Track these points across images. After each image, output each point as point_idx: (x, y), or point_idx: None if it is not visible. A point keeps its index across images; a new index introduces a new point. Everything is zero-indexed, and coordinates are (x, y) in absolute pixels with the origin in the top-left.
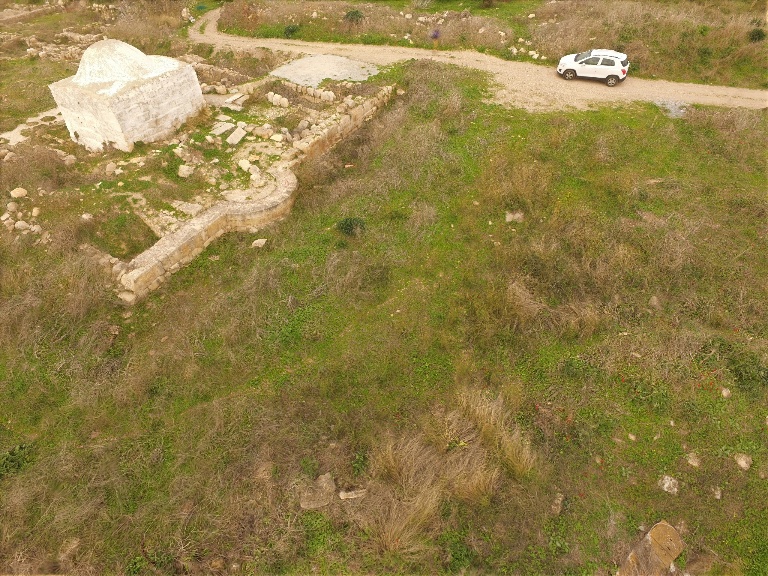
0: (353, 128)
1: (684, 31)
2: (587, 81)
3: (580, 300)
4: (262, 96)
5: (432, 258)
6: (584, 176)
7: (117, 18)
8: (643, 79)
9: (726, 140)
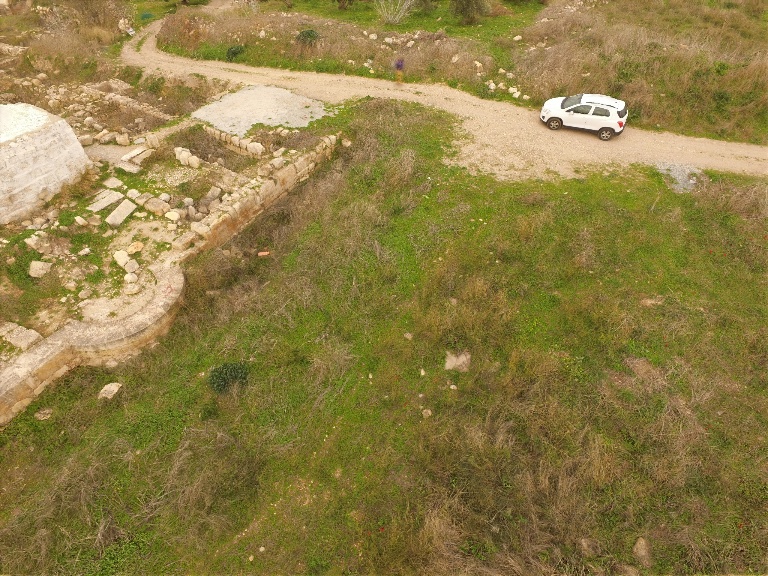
0: (281, 193)
1: (697, 69)
2: (576, 131)
3: (531, 542)
4: (168, 152)
5: (332, 437)
6: (559, 290)
7: (48, 28)
8: (645, 130)
9: (748, 233)
